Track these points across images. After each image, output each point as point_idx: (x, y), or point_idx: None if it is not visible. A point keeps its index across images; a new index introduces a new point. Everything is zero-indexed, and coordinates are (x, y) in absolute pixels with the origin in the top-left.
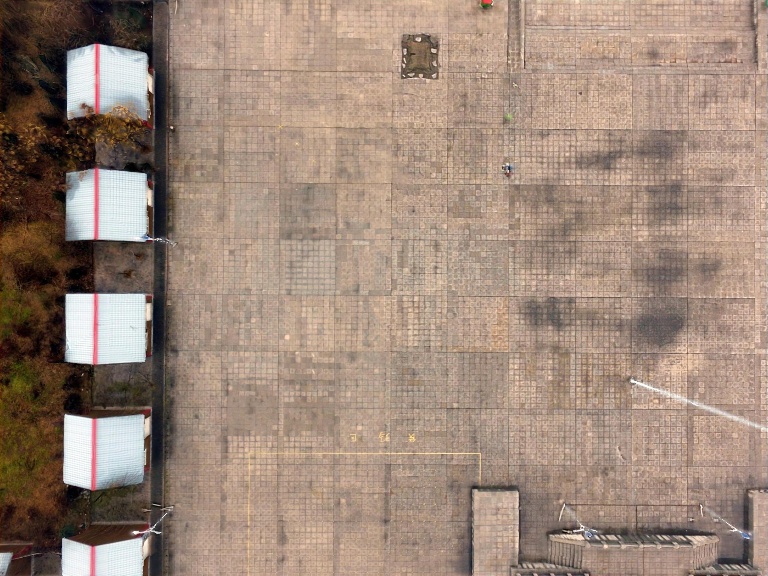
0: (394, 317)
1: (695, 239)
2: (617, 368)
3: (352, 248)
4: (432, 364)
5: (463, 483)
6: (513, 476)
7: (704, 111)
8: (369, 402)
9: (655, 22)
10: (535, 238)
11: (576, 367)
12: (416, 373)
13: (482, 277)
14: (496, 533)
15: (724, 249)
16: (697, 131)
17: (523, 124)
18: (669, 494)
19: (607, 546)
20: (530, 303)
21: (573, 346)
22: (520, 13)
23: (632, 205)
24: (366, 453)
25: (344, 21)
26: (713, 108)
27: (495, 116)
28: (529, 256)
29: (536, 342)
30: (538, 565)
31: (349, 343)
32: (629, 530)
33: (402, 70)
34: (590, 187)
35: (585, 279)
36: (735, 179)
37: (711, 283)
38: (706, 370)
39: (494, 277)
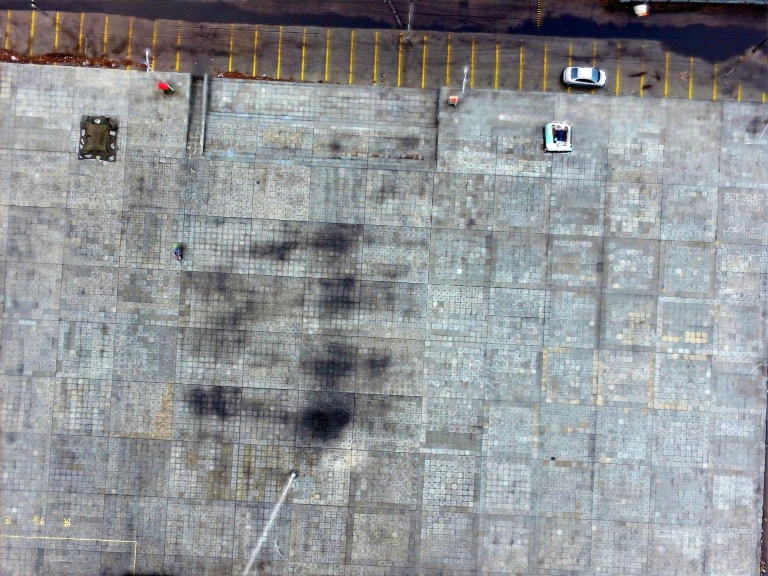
0: (57, 399)
1: (365, 334)
2: (280, 461)
3: (18, 327)
4: (93, 448)
5: (116, 571)
6: (168, 566)
7: (381, 206)
8: (26, 484)
9: (340, 114)
10: (204, 326)
11: (238, 458)
12: (76, 457)
13: (149, 362)
14: None
15: (394, 346)
16: (373, 226)
17: (199, 211)
18: None
19: None
20: (196, 391)
21: (237, 437)
22: (203, 99)
23: (304, 297)
24: (19, 536)
25: (23, 99)
26: (390, 204)
27: (171, 201)
28: (197, 343)
29: (199, 431)
30: None
31: (9, 423)
32: None
33: (79, 151)
34: (263, 277)
35: (253, 369)
36: (409, 276)
37: (379, 379)
38: (370, 467)
39: (161, 363)
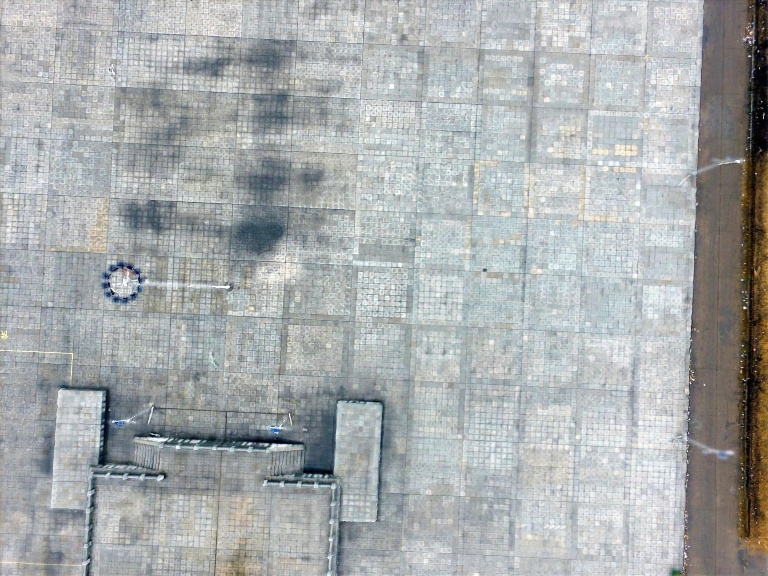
0: None
1: (298, 149)
2: (214, 274)
3: None
4: (29, 262)
5: (53, 382)
6: (104, 377)
7: (313, 22)
8: None
9: None
10: (139, 141)
11: (173, 271)
12: (12, 270)
13: (84, 177)
14: (77, 432)
15: (327, 160)
16: (306, 42)
17: (132, 27)
18: (260, 402)
19: (179, 447)
20: (131, 205)
21: (172, 250)
22: None
23: (237, 112)
24: None
25: None
26: (322, 20)
27: (105, 18)
28: (132, 159)
29: (135, 245)
30: (120, 466)
31: None
32: (217, 436)
33: None
34: (197, 93)
35: (187, 184)
36: (341, 91)
37: (312, 193)
38: (303, 280)
39: (96, 178)
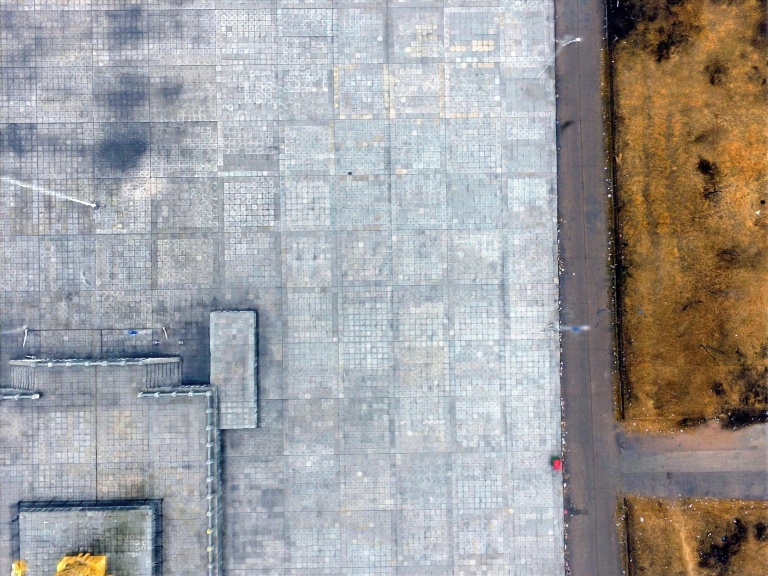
0: None
1: (156, 63)
2: (80, 193)
3: None
4: None
5: None
6: None
7: None
8: None
9: None
10: None
11: (38, 193)
12: None
13: None
14: None
15: (185, 73)
16: None
17: None
18: (134, 318)
19: (51, 364)
20: None
21: (35, 172)
22: None
23: (92, 30)
24: None
25: None
26: None
27: None
28: None
29: None
30: None
31: None
32: (94, 354)
33: None
34: (49, 12)
35: (46, 105)
36: (195, 3)
37: (173, 107)
38: (169, 194)
39: None
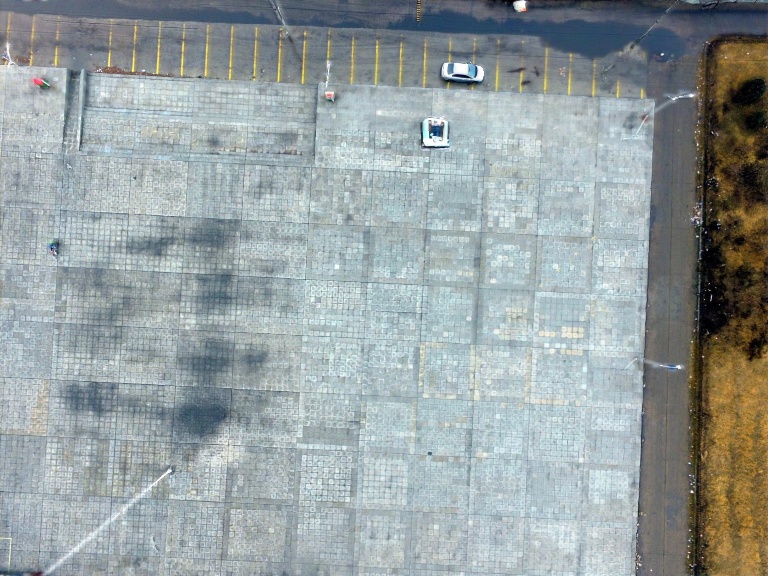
0: None
1: (242, 330)
2: (156, 457)
3: None
4: None
5: None
6: (43, 563)
7: (258, 202)
8: None
9: (219, 110)
10: (81, 321)
11: (115, 454)
12: None
13: (24, 358)
14: None
15: (271, 341)
16: (250, 221)
17: (75, 206)
18: None
19: None
20: (72, 387)
21: (113, 433)
22: None
23: (181, 293)
24: None
25: None
26: (268, 199)
27: (47, 197)
28: (74, 339)
29: (75, 427)
30: None
31: None
32: None
33: None
34: (140, 272)
35: (129, 365)
36: (286, 271)
37: (256, 375)
38: (246, 463)
39: (37, 359)
